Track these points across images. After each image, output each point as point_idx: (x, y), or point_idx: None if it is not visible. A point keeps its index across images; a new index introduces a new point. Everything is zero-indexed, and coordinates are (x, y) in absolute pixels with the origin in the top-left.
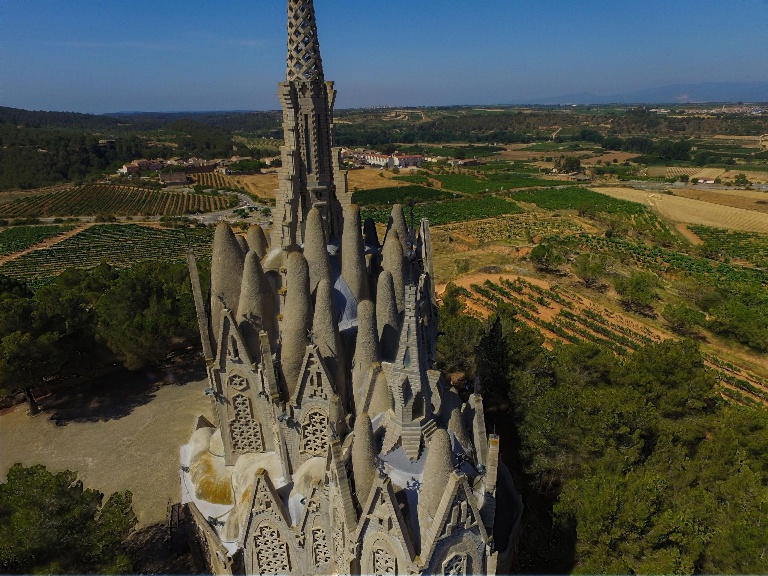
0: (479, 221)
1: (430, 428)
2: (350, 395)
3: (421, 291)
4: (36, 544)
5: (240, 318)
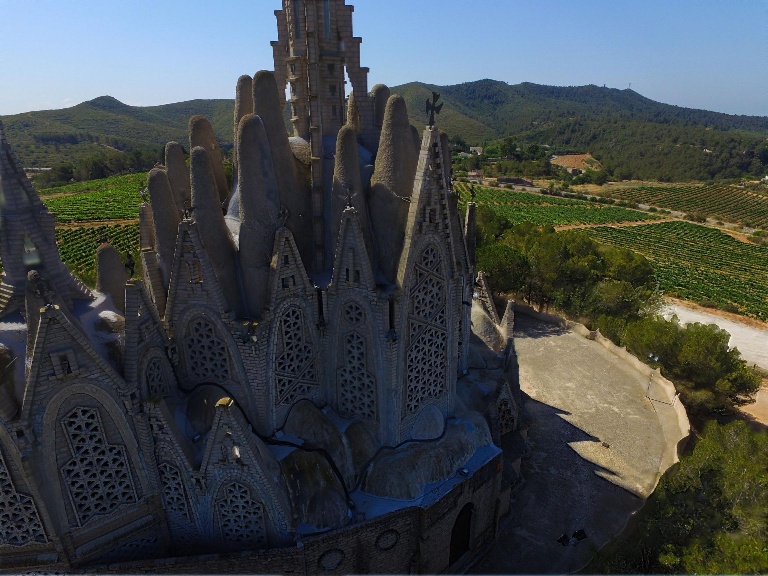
0: None
1: (6, 292)
2: None
3: (282, 212)
4: None
5: None
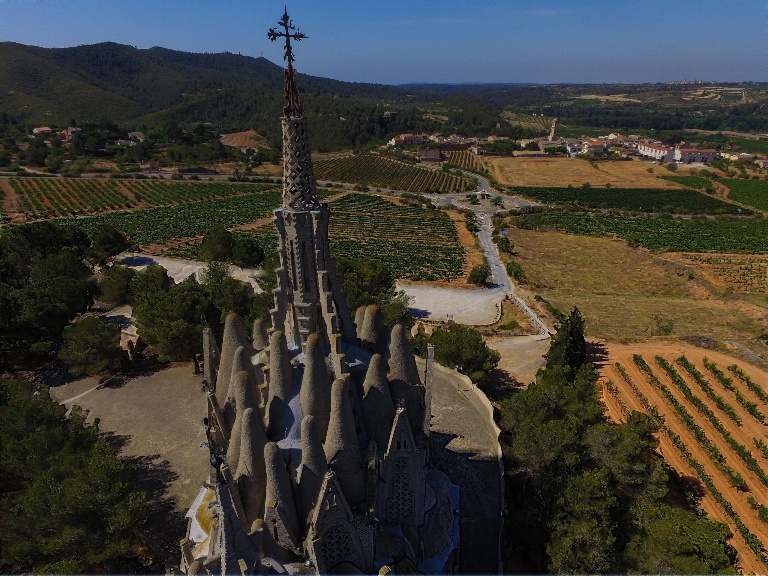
0: (752, 256)
1: None
2: (262, 514)
3: None
4: (76, 510)
5: (227, 399)
